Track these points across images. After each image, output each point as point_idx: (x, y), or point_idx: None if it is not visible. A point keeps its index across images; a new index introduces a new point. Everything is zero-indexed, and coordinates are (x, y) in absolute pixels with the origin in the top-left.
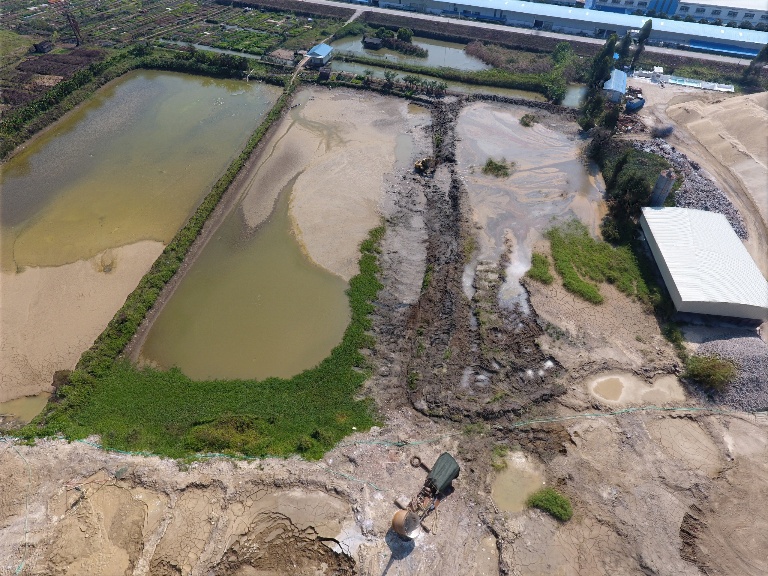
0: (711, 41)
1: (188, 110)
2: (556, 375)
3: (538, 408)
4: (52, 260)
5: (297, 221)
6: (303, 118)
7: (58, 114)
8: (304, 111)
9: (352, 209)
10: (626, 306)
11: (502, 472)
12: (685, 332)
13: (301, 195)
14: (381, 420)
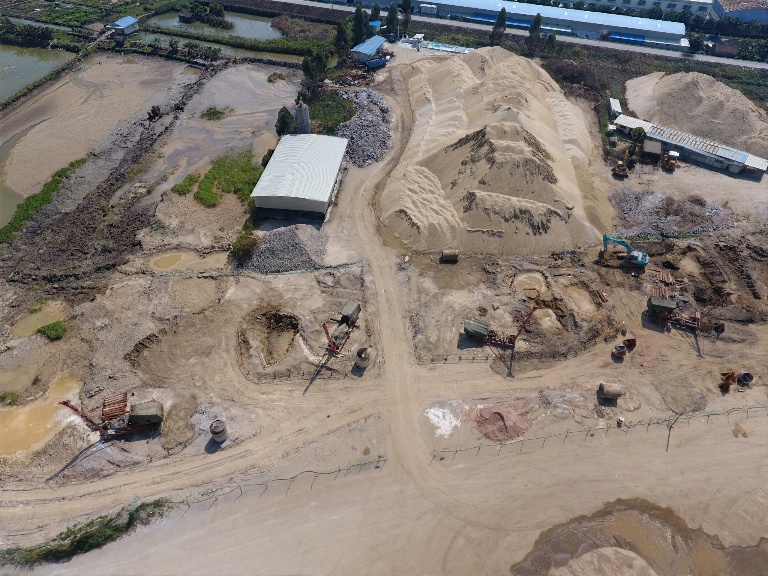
0: (490, 13)
1: None
2: (131, 253)
3: (98, 274)
4: None
5: (14, 156)
6: (80, 78)
7: None
8: (85, 73)
9: (69, 146)
10: (233, 208)
11: (34, 313)
12: (263, 224)
13: (32, 137)
14: None
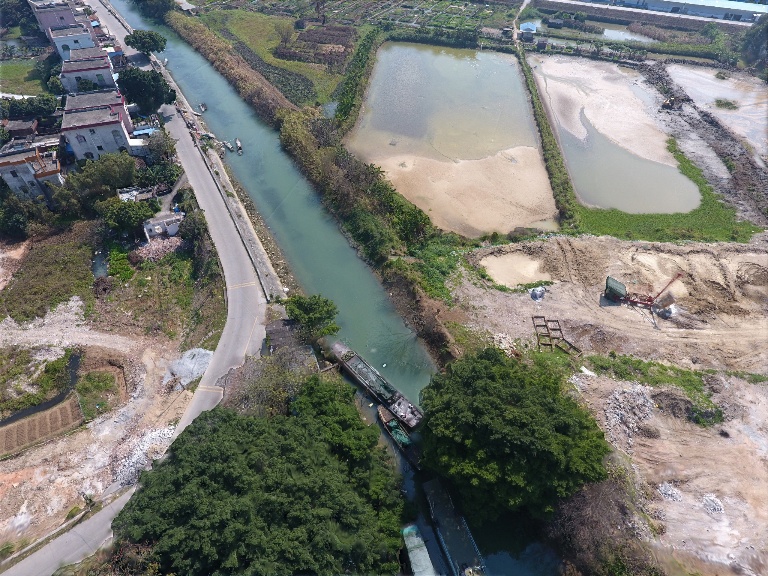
0: None
1: (458, 69)
2: None
3: None
4: (471, 156)
5: (610, 136)
6: (549, 75)
7: (370, 70)
8: (545, 70)
9: (641, 129)
10: None
11: None
12: None
13: (597, 121)
14: (766, 228)
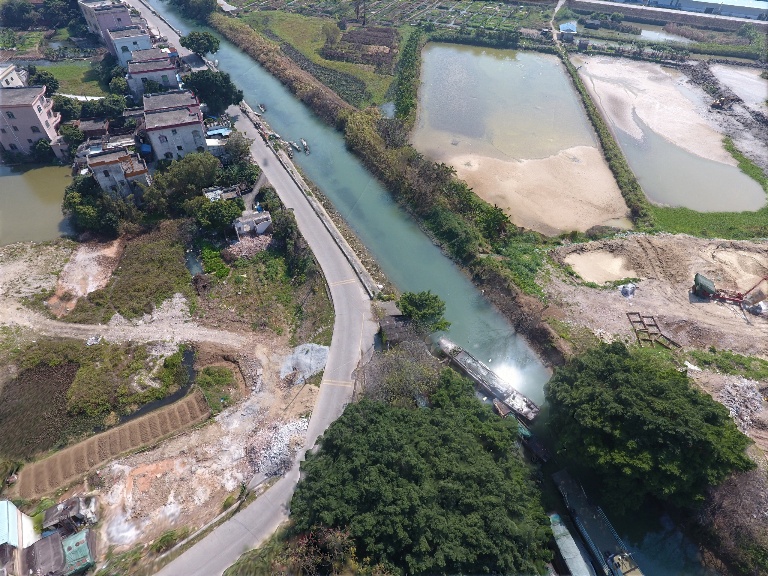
0: None
1: (504, 70)
2: None
3: None
4: (533, 156)
5: (666, 136)
6: (594, 75)
7: (419, 71)
8: (589, 71)
9: (695, 129)
10: None
11: None
12: None
13: (650, 121)
14: None
